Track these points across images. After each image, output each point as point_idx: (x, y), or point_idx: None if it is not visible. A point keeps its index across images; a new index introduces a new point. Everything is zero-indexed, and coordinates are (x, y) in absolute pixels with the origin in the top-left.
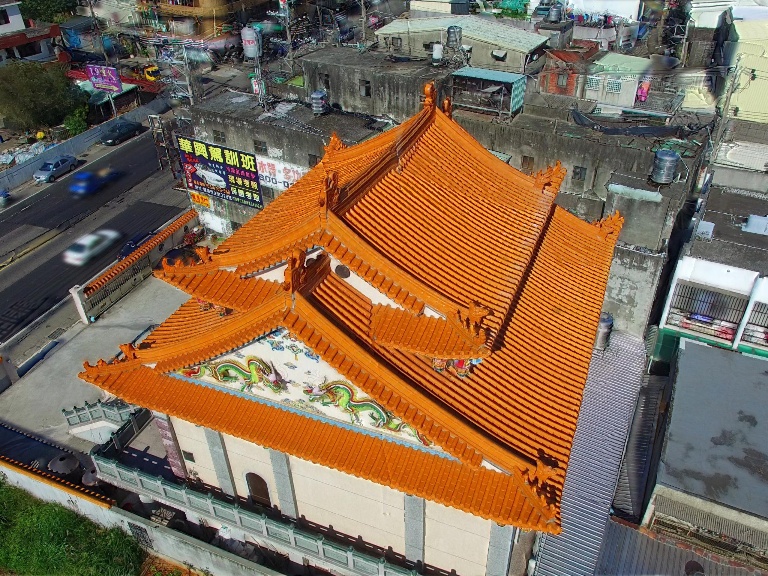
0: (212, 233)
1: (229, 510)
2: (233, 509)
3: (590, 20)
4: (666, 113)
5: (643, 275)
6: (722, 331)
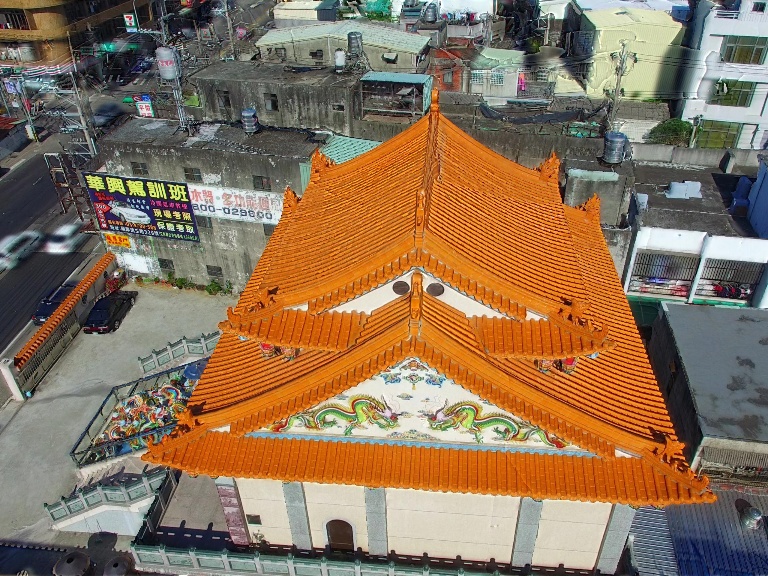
0: (135, 275)
1: (314, 566)
2: (321, 564)
3: (454, 18)
4: (547, 100)
5: (614, 250)
6: (678, 289)
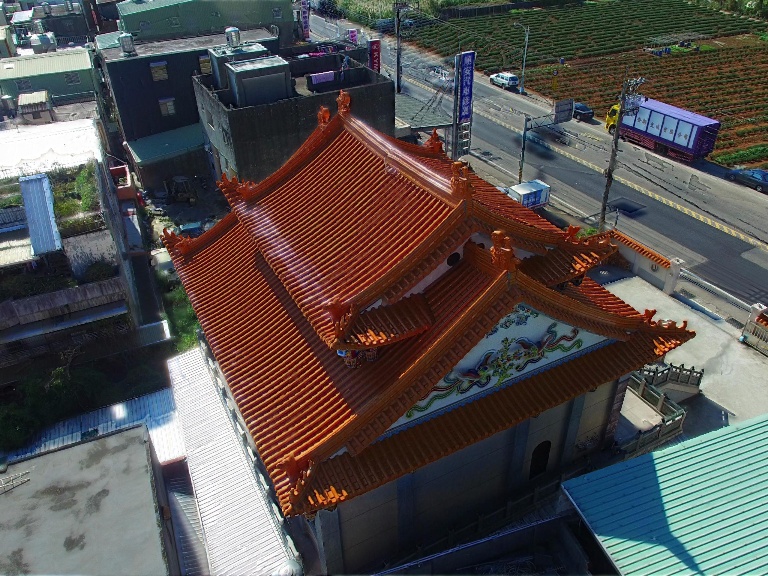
0: None
1: None
2: None
3: None
4: None
5: None
6: None
